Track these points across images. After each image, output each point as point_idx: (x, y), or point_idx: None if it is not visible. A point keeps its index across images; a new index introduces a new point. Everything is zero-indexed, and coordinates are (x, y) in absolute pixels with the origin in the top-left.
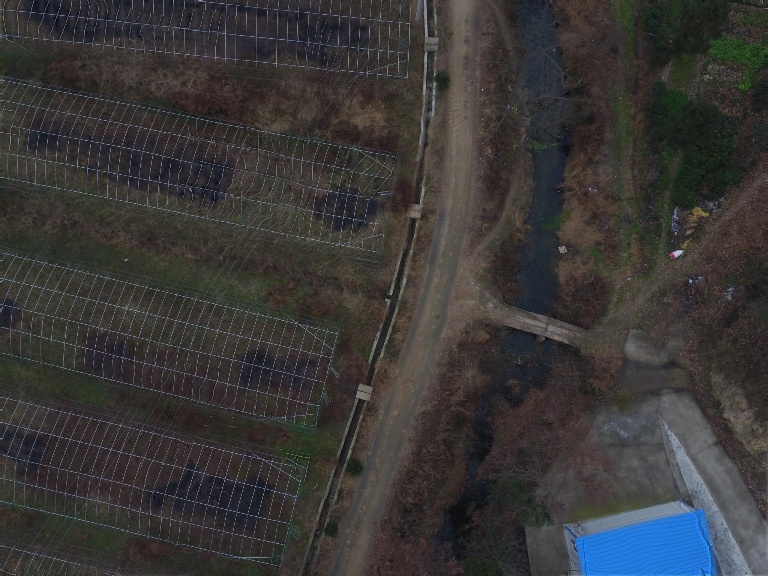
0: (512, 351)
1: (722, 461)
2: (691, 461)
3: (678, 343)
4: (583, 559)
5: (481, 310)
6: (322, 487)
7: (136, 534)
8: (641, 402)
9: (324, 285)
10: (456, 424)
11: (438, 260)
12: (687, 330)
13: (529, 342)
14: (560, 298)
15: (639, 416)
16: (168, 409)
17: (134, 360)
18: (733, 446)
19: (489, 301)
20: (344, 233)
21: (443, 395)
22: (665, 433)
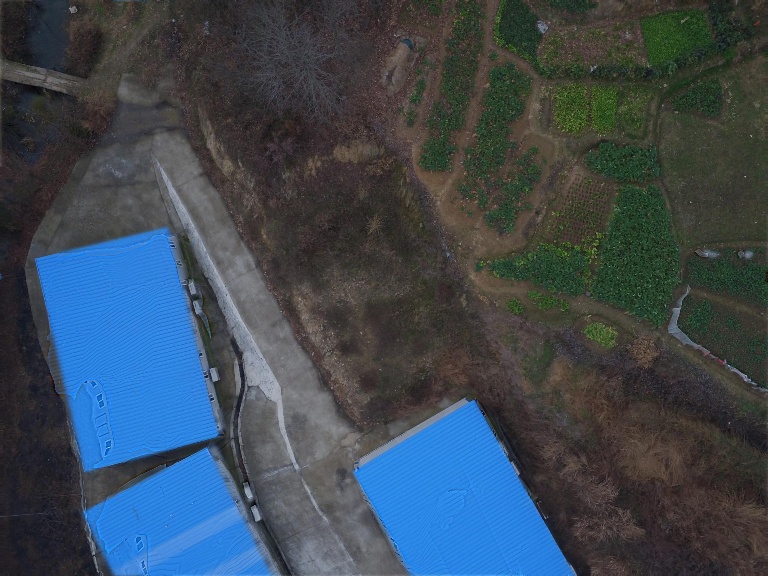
0: (25, 110)
1: (206, 190)
2: (176, 192)
3: (169, 83)
4: None
5: None
6: None
7: None
8: (135, 143)
9: None
10: None
11: None
12: (177, 70)
13: (36, 98)
14: (63, 52)
15: (133, 156)
16: None
17: None
18: (216, 175)
19: None
20: None
21: None
22: (158, 171)
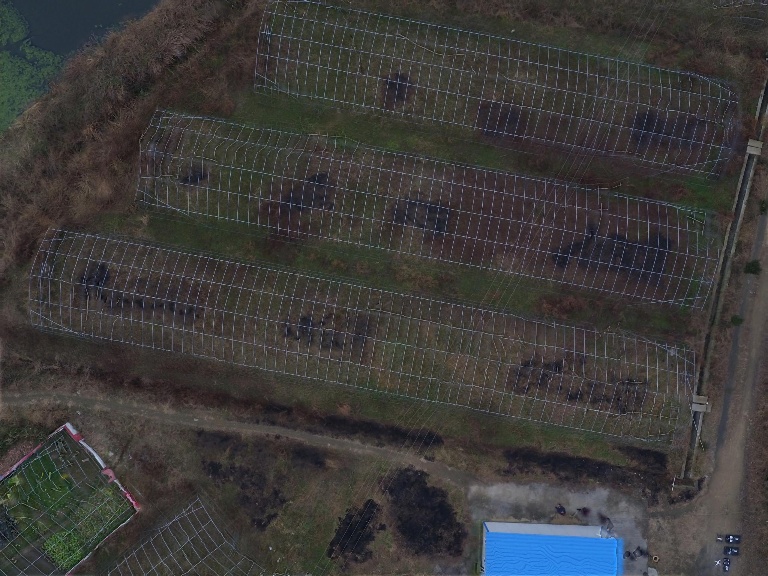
0: None
1: None
2: None
3: None
4: None
5: None
6: (719, 241)
7: (560, 282)
8: None
9: (707, 47)
10: None
11: None
12: None
13: None
14: None
15: None
16: (578, 163)
17: (551, 111)
18: None
19: None
20: None
21: None
22: None
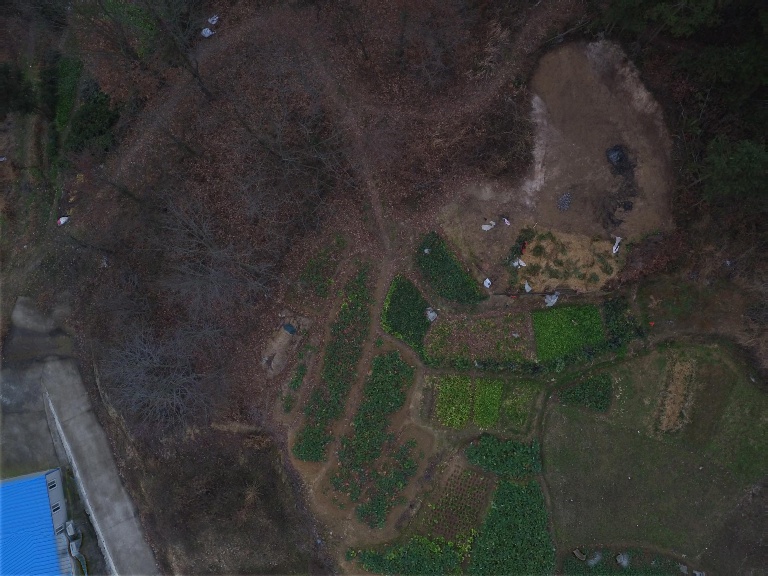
0: None
1: (92, 428)
2: (61, 428)
3: (65, 310)
4: None
5: None
6: None
7: None
8: (26, 369)
9: None
10: None
11: None
12: (73, 297)
13: None
14: None
15: (22, 383)
16: None
17: None
18: (103, 413)
19: None
20: None
21: None
22: (47, 400)
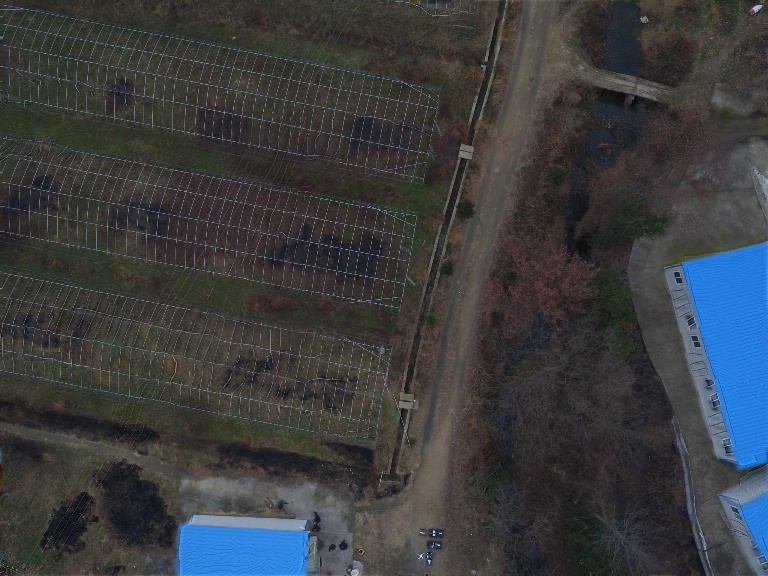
0: (602, 116)
1: None
2: None
3: (762, 93)
4: (689, 283)
5: (572, 72)
6: (430, 243)
7: (260, 282)
8: (730, 150)
9: (423, 54)
10: (554, 180)
11: (529, 27)
12: None
13: (618, 104)
14: (646, 61)
15: (729, 163)
16: (284, 168)
17: (252, 117)
18: None
19: (579, 64)
20: (439, 5)
21: (541, 150)
22: (755, 178)
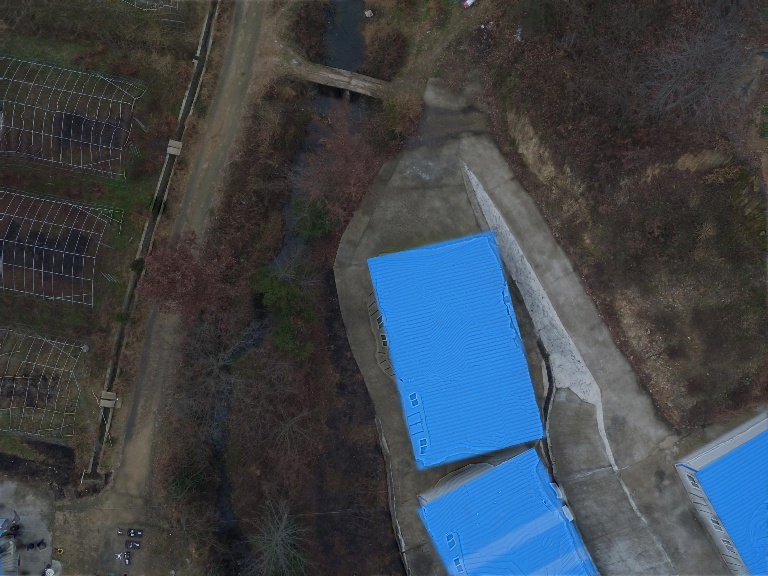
0: (322, 111)
1: (518, 194)
2: (488, 195)
3: (476, 88)
4: (375, 280)
5: (285, 67)
6: (136, 240)
7: None
8: (442, 146)
9: (134, 49)
10: (264, 176)
11: (242, 21)
12: (484, 75)
13: (336, 100)
14: (364, 55)
15: (440, 159)
16: None
17: None
18: (528, 179)
19: (293, 58)
20: None
21: (249, 146)
22: (465, 174)
